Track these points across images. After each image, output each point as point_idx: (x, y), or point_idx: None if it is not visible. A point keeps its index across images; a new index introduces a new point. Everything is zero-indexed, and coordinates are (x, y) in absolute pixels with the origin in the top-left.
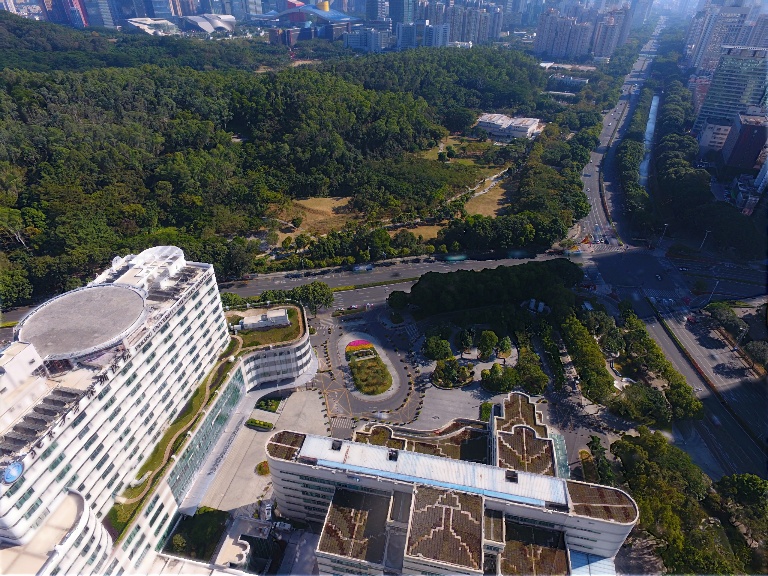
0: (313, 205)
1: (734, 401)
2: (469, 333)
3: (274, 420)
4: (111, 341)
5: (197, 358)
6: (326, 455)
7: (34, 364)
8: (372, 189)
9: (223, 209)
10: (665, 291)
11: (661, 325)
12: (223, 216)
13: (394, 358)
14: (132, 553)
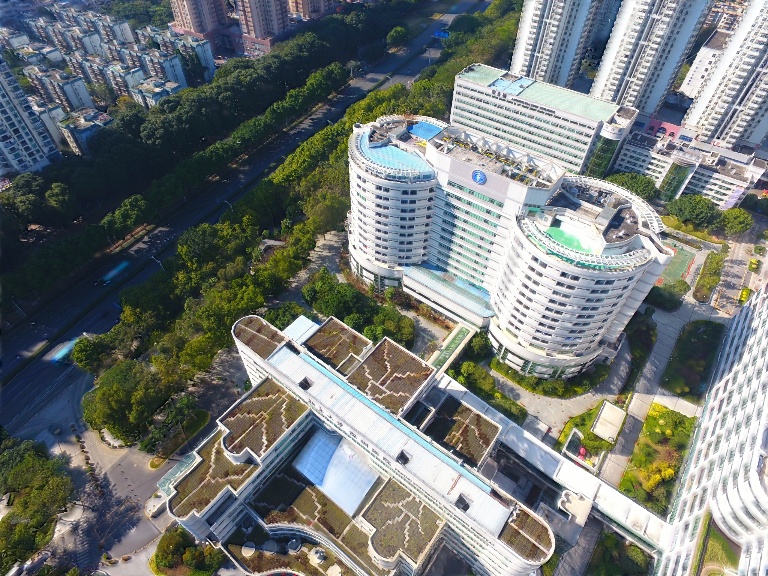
0: None
1: None
2: None
3: None
4: None
5: None
6: (478, 495)
7: None
8: None
9: None
10: None
11: None
12: None
13: None
14: None
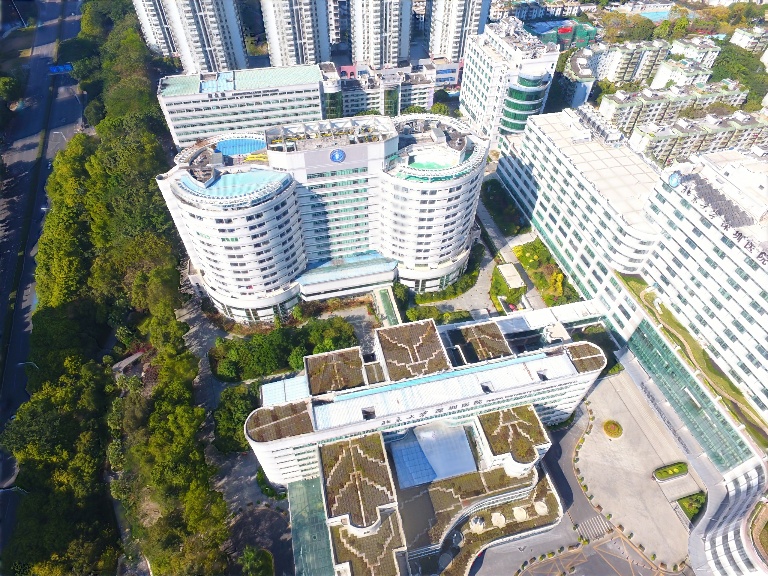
0: None
1: None
2: None
3: (666, 489)
4: None
5: None
6: (544, 363)
7: None
8: None
9: None
10: None
11: None
12: None
13: None
14: (608, 290)
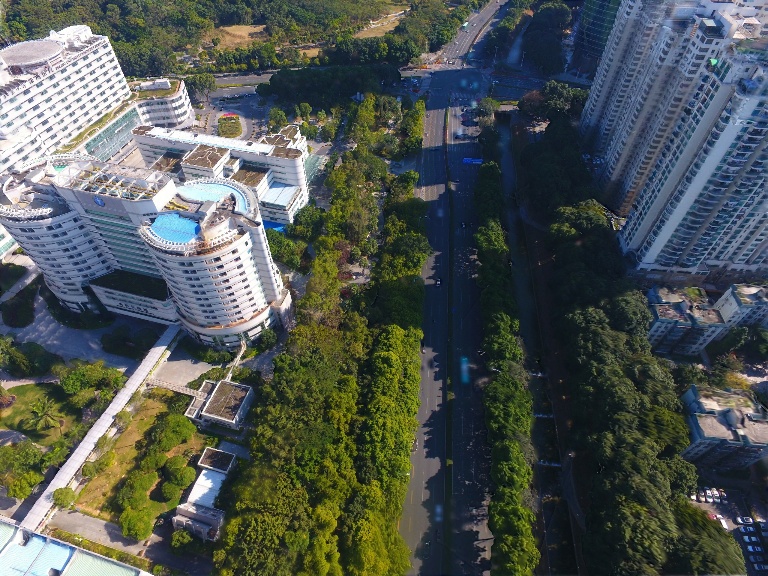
0: (235, 31)
1: (454, 151)
2: (299, 108)
3: None
4: (41, 60)
5: (104, 94)
6: (161, 134)
7: (3, 65)
8: (281, 17)
9: (160, 30)
10: (468, 94)
11: (445, 113)
12: (159, 35)
13: (249, 123)
14: None
